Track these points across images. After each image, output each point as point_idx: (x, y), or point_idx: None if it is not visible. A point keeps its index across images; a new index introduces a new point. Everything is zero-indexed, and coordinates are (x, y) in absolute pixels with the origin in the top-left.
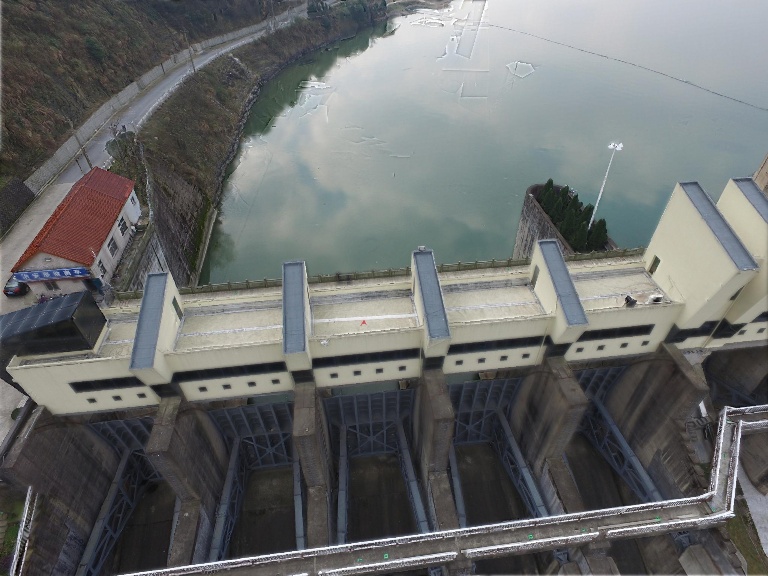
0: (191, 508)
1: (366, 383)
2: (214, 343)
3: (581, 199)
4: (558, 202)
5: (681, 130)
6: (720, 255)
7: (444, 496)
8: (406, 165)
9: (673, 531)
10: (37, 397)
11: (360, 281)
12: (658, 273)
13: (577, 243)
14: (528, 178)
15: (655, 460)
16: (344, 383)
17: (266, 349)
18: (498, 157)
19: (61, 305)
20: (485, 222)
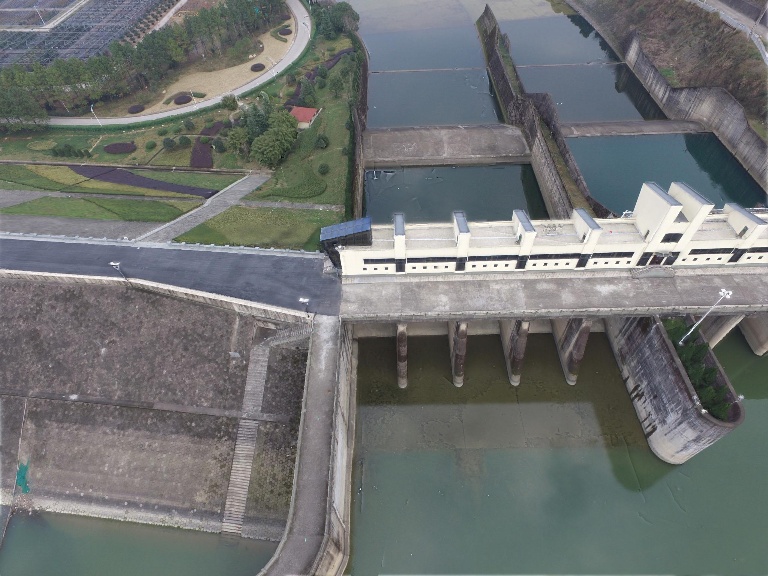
0: None
1: None
2: None
3: None
4: None
5: None
6: None
7: None
8: None
9: None
10: None
11: None
12: None
13: None
14: None
15: None
16: None
17: None
18: None
19: None
20: None
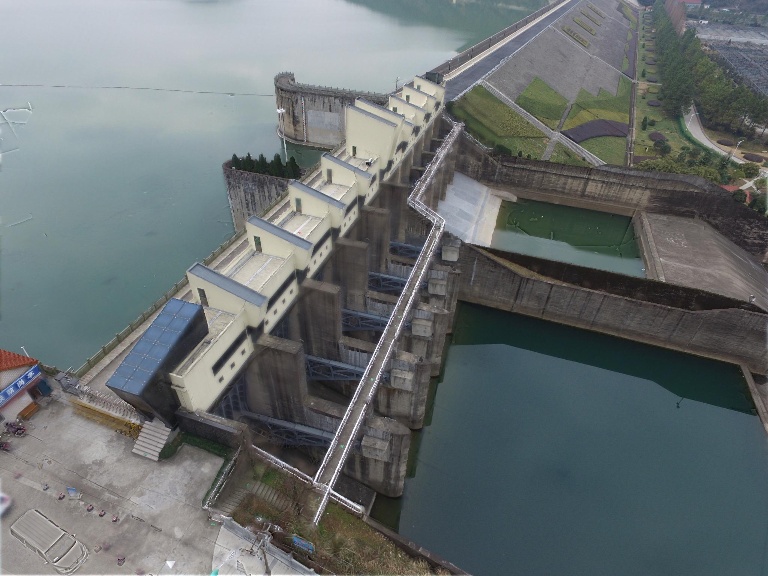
0: (309, 400)
1: (316, 270)
2: (256, 286)
3: (213, 180)
4: (256, 162)
5: (213, 119)
6: (384, 126)
7: (380, 295)
8: (41, 224)
9: (439, 240)
10: (194, 401)
11: (227, 251)
12: (359, 153)
13: (291, 175)
14: (161, 185)
15: (407, 236)
16: (311, 274)
17: (288, 264)
18: (116, 183)
19: (172, 314)
20: (176, 223)
